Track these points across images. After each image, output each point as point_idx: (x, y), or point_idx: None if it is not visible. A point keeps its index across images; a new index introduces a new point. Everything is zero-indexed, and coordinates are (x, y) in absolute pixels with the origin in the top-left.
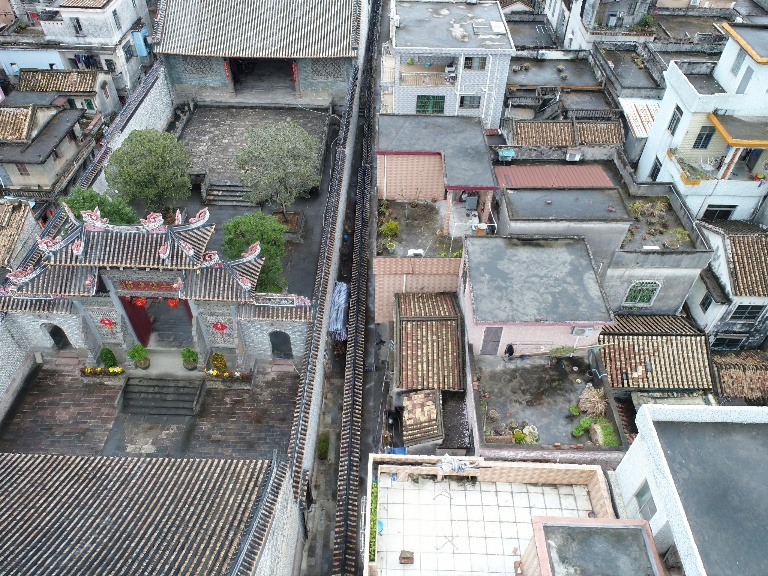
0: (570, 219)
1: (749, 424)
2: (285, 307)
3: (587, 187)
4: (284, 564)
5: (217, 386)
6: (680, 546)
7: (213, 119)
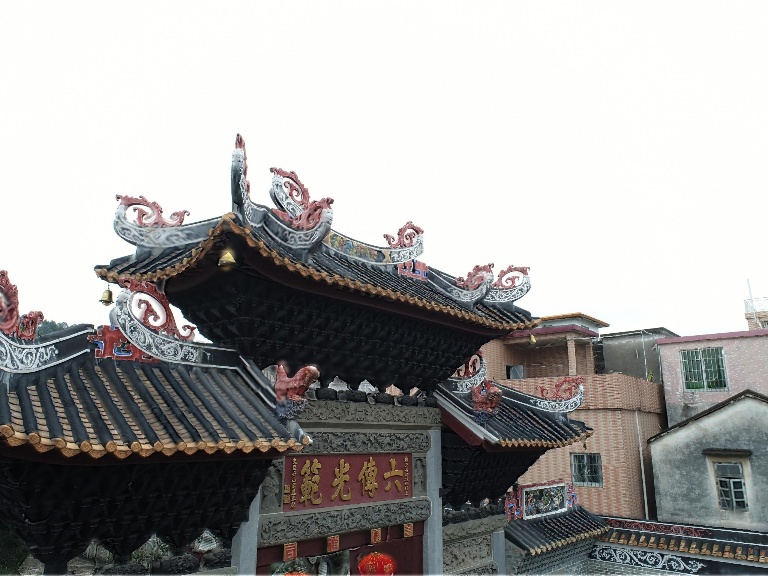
0: None
1: None
2: (557, 517)
3: None
4: None
5: None
6: None
7: None
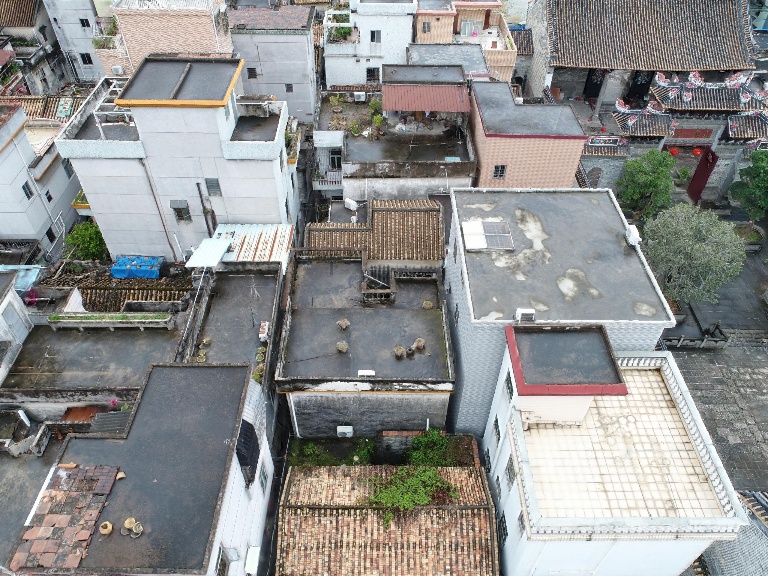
0: (424, 65)
1: None
2: None
3: (406, 80)
4: None
5: None
6: None
7: None
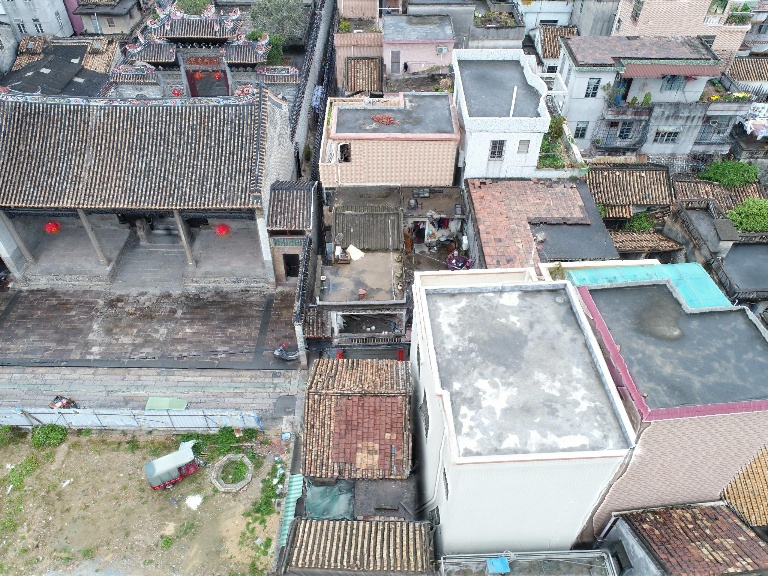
0: (441, 3)
1: (505, 60)
2: (284, 76)
3: None
4: (286, 158)
5: None
6: (457, 85)
7: None
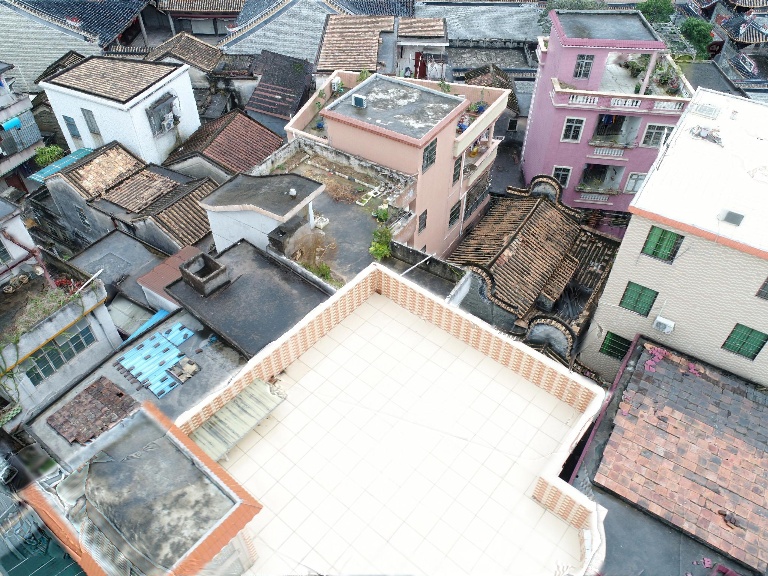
0: None
1: None
2: None
3: None
4: None
5: None
6: None
7: None
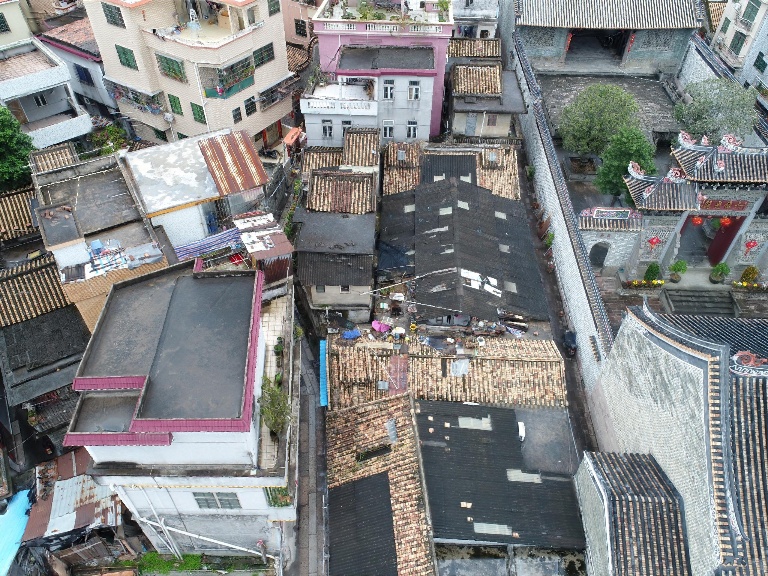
0: None
1: None
2: None
3: None
4: None
5: (737, 297)
6: None
7: (558, 86)
